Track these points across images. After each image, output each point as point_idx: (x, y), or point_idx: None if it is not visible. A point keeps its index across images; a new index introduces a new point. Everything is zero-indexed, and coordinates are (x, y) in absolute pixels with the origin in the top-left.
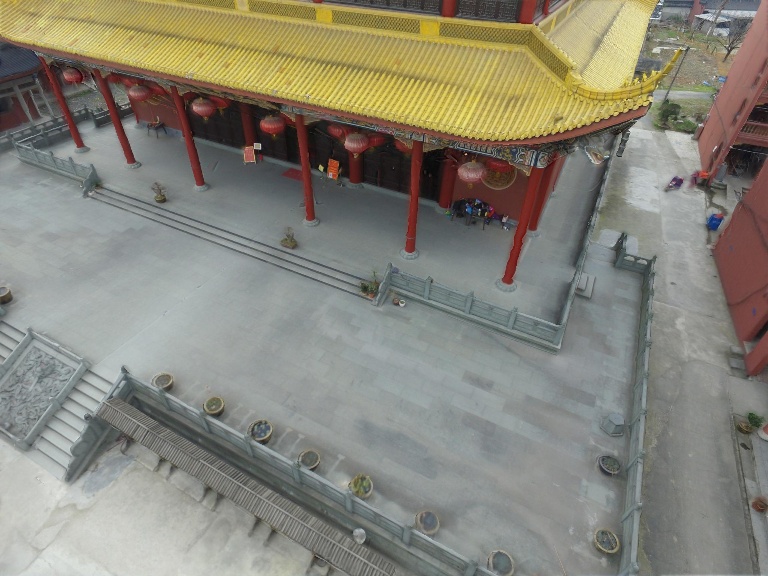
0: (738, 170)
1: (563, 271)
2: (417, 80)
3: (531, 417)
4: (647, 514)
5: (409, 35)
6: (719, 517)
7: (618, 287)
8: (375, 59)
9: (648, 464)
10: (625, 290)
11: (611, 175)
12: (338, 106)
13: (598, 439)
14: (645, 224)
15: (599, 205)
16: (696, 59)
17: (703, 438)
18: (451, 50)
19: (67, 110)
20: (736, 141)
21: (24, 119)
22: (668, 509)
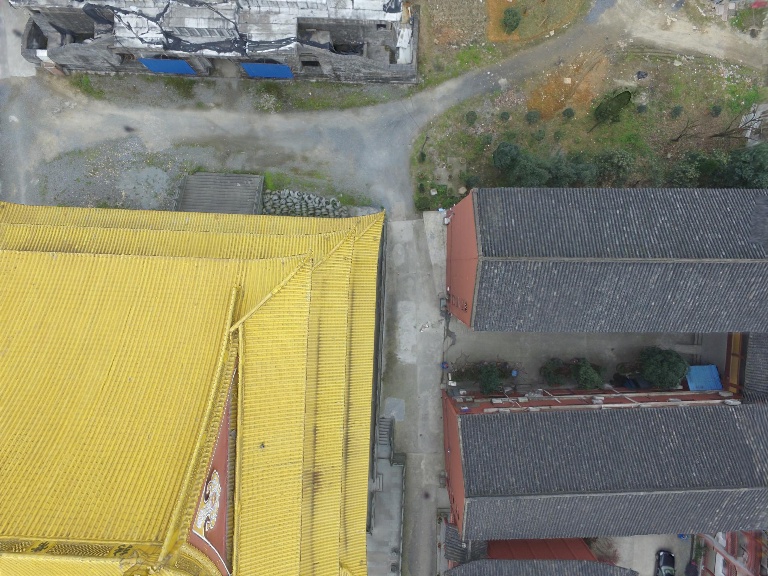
0: None
1: (368, 484)
2: None
3: (370, 559)
4: (409, 558)
5: None
6: (429, 550)
7: (393, 476)
8: None
9: (409, 541)
10: (396, 477)
11: (386, 324)
12: None
13: (391, 558)
14: (408, 381)
15: (382, 371)
16: None
17: (427, 523)
18: None
19: None
20: None
21: None
22: (415, 554)
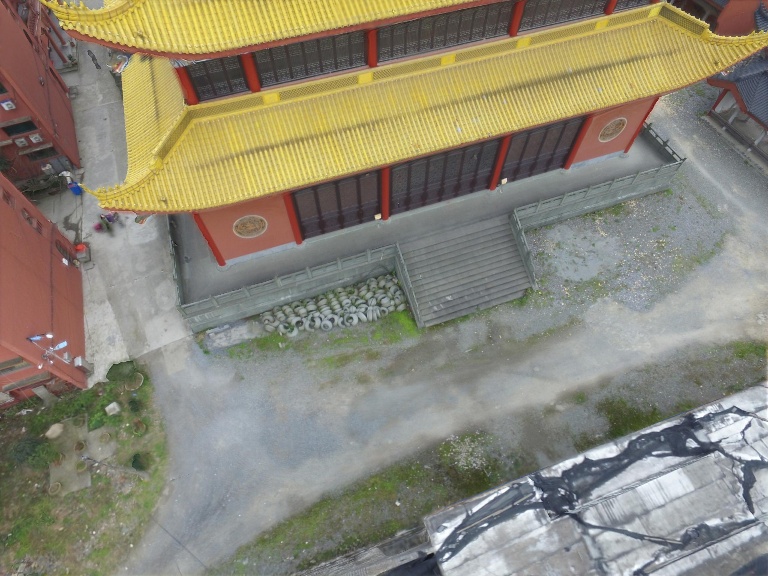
0: None
1: None
2: None
3: None
4: None
5: None
6: None
7: None
8: None
9: None
10: None
11: None
12: None
13: None
14: None
15: None
16: None
17: None
18: None
19: None
20: None
21: None
22: None
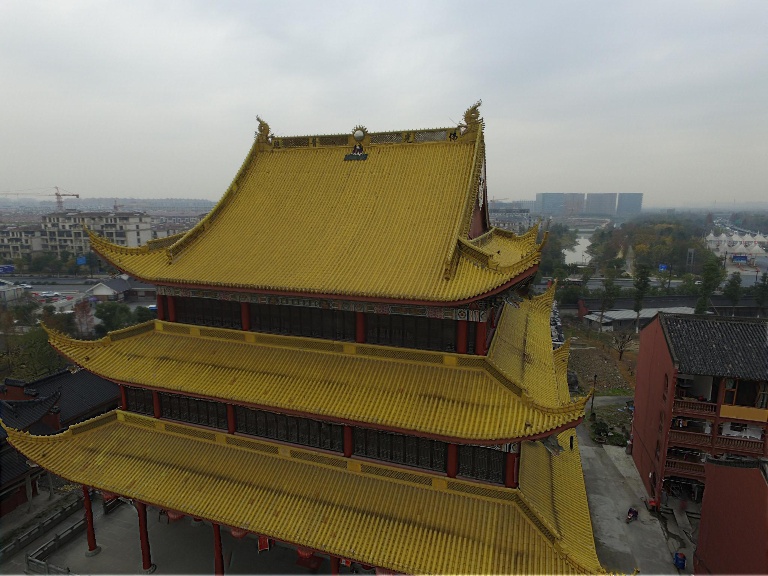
0: (675, 492)
1: None
2: (439, 532)
3: None
4: None
5: (424, 486)
6: None
7: None
8: (401, 509)
9: None
10: None
11: None
12: (380, 563)
13: None
14: (625, 570)
15: None
16: (599, 359)
17: None
18: (458, 501)
19: (91, 517)
20: (665, 474)
21: (21, 501)
22: None
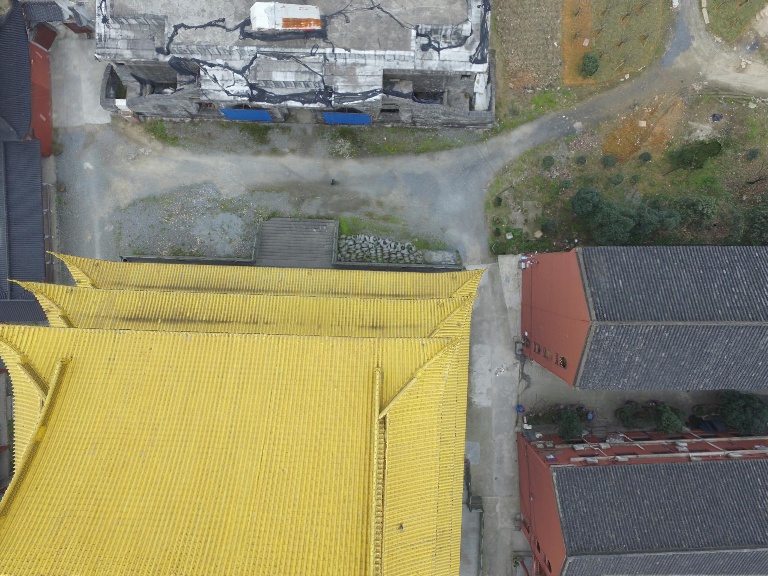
0: None
1: None
2: None
3: None
4: None
5: None
6: None
7: (470, 521)
8: None
9: None
10: (473, 522)
11: None
12: None
13: None
14: (483, 424)
15: None
16: None
17: (502, 567)
18: None
19: None
20: None
21: None
22: None
